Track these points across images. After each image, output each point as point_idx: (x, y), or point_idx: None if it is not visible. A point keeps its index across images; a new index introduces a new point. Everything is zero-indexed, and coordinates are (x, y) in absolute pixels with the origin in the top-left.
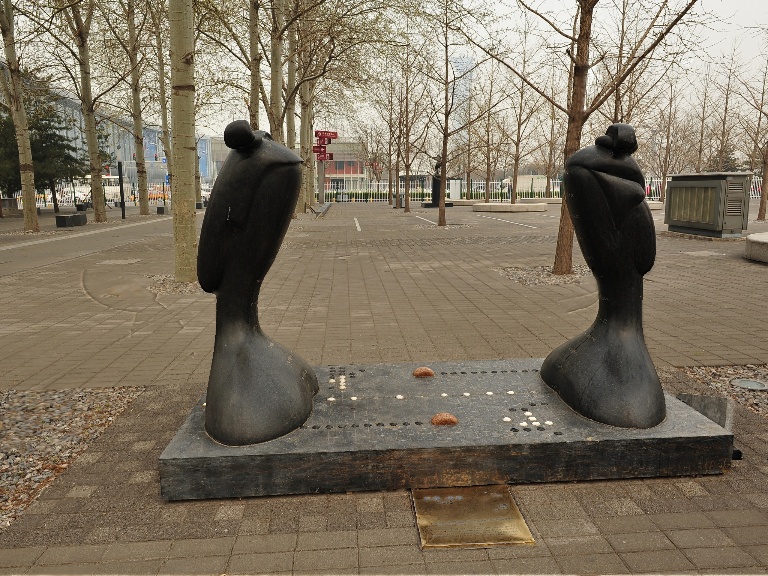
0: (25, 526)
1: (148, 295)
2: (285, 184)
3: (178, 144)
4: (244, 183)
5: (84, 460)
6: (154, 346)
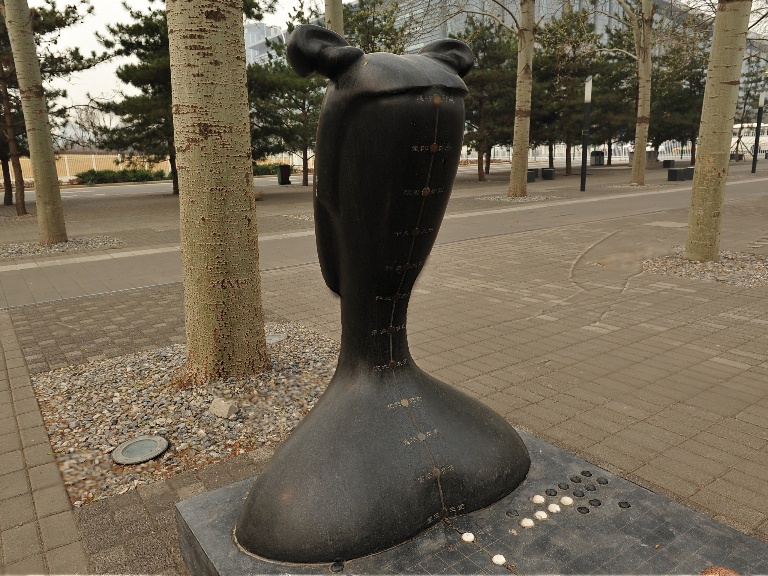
0: (115, 503)
1: (633, 270)
2: (380, 135)
3: (714, 79)
4: (325, 136)
5: (253, 455)
6: (528, 338)
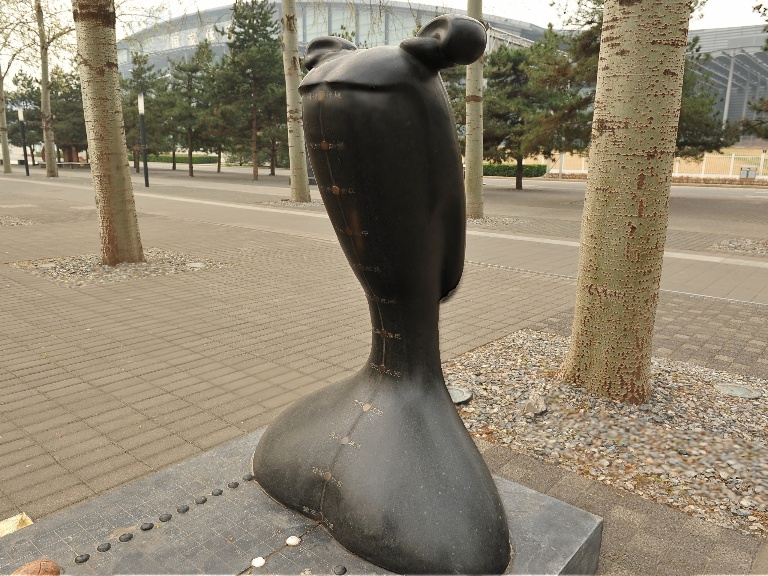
0: None
1: None
2: None
3: None
4: None
5: None
6: None
